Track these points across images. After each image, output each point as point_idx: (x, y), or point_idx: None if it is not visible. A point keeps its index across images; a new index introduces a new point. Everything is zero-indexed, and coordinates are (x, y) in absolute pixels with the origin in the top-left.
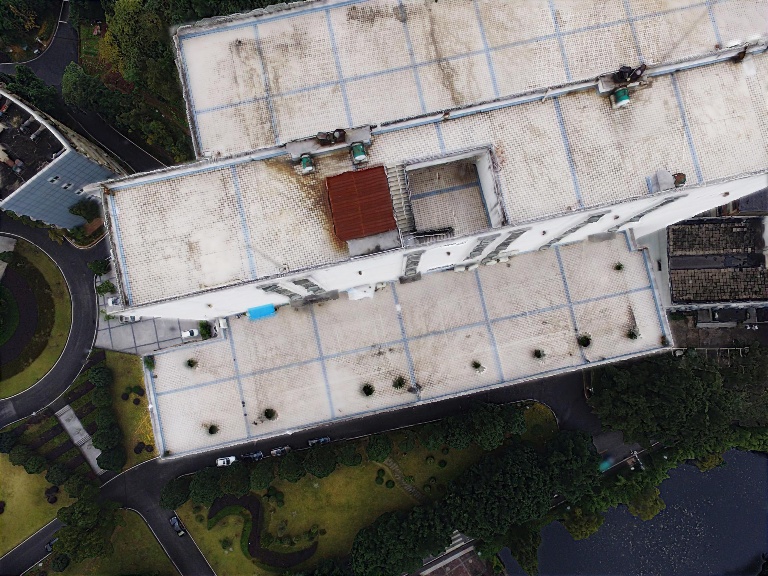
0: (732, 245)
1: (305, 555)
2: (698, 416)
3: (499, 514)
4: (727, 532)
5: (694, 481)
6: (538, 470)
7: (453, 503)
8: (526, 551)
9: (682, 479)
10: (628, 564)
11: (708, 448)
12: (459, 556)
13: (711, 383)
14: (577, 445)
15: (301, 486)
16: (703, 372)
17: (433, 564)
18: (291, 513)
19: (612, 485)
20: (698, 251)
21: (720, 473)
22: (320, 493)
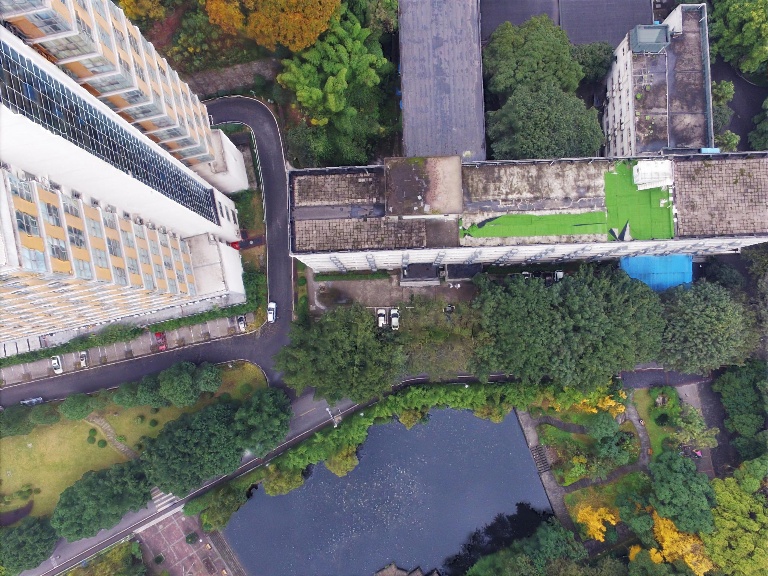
0: (357, 195)
1: (20, 514)
2: (349, 368)
3: (181, 469)
4: (439, 489)
5: (408, 440)
6: (222, 426)
7: (146, 460)
8: (213, 506)
9: (397, 438)
10: (341, 521)
11: (402, 405)
12: (172, 514)
13: (357, 335)
14: (262, 401)
15: (15, 446)
16: (352, 324)
17: (146, 522)
18: (6, 473)
19: (312, 442)
20: (323, 201)
21: (434, 432)
22: (34, 453)
